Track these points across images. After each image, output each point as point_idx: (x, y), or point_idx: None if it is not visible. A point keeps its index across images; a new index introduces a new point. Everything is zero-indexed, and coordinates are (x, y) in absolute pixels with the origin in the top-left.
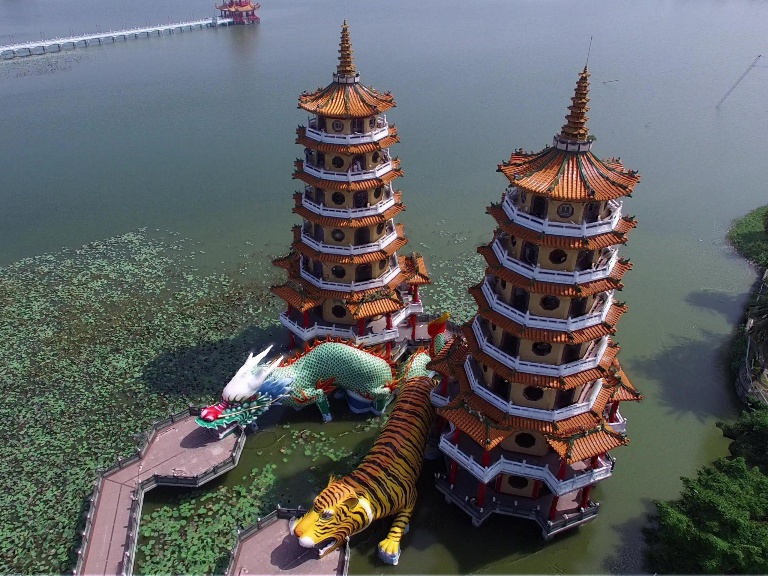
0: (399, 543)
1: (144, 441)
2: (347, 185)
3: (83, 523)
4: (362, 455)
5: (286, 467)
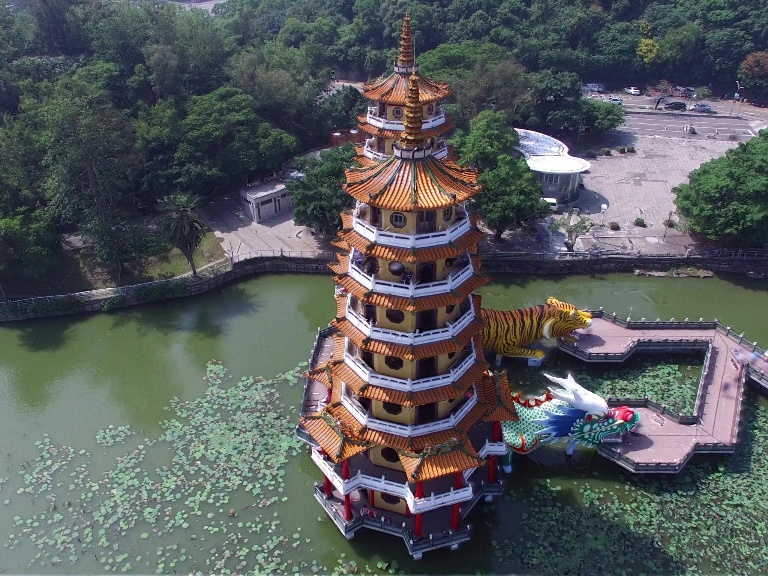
0: None
1: None
2: None
3: None
4: None
5: None
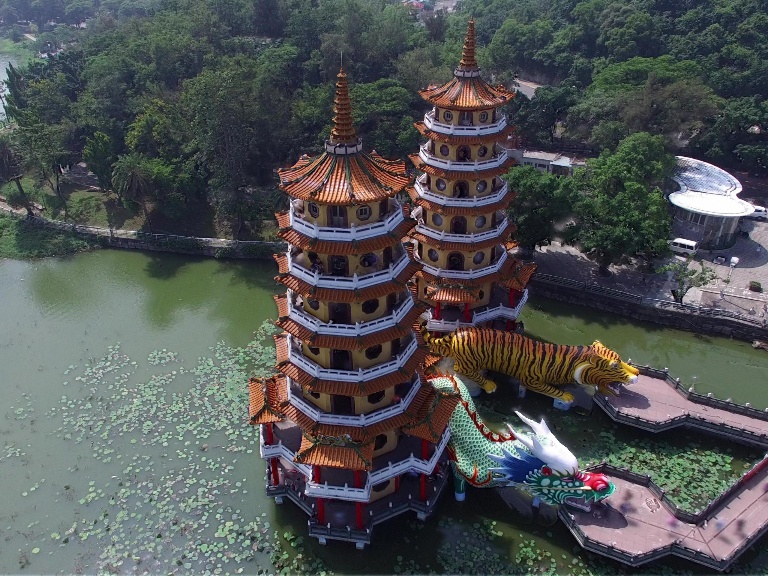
0: None
1: None
2: (410, 246)
3: (754, 575)
4: (502, 415)
5: None
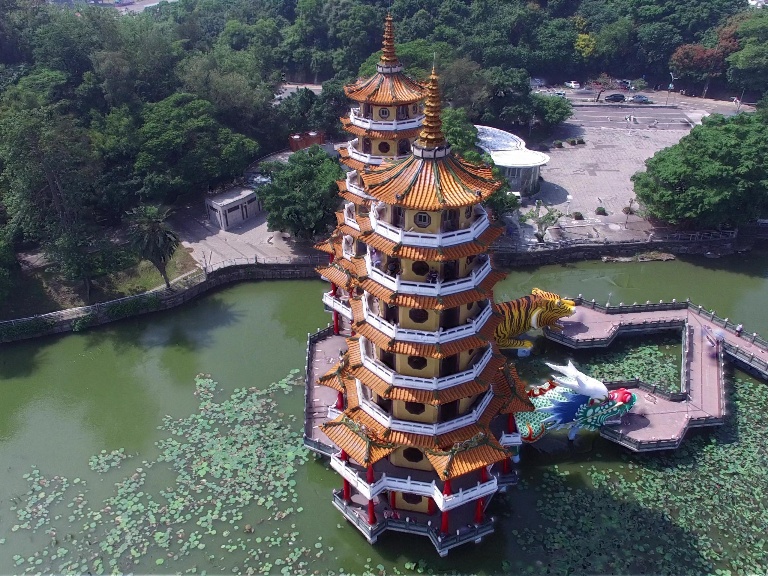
0: None
1: None
2: None
3: None
4: None
5: None
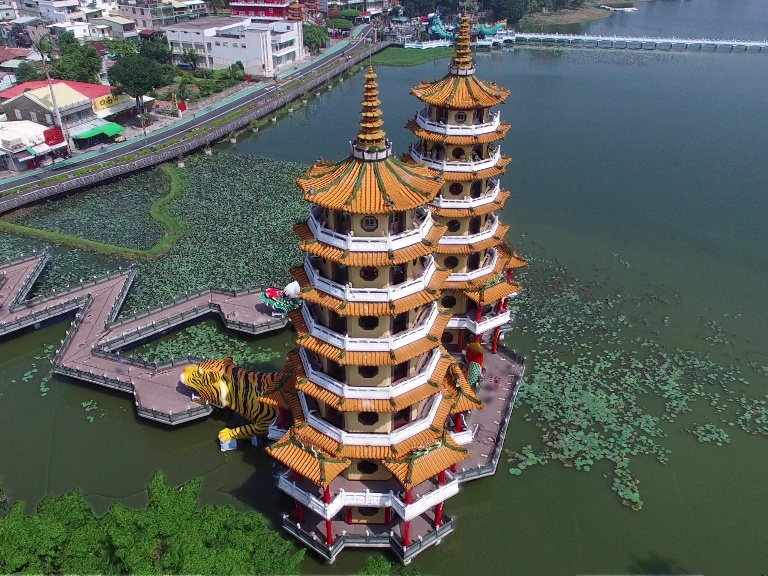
0: (236, 441)
1: (245, 288)
2: None
3: None
4: None
5: (282, 361)
